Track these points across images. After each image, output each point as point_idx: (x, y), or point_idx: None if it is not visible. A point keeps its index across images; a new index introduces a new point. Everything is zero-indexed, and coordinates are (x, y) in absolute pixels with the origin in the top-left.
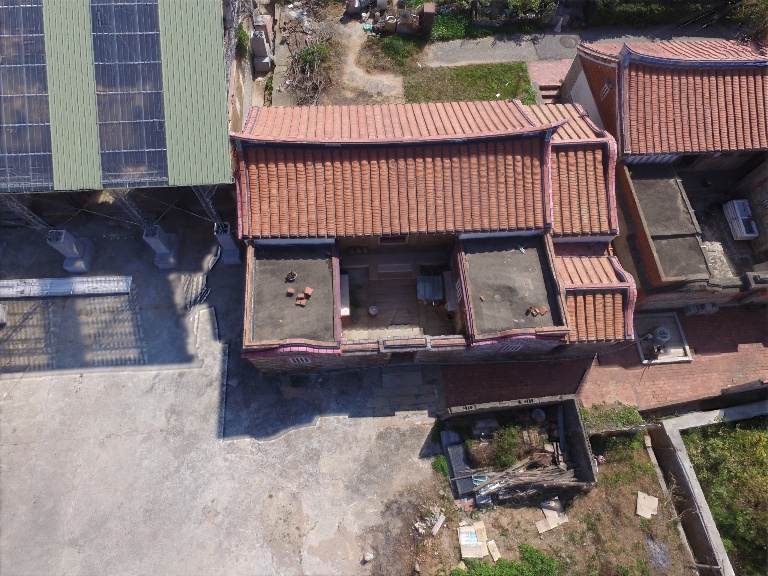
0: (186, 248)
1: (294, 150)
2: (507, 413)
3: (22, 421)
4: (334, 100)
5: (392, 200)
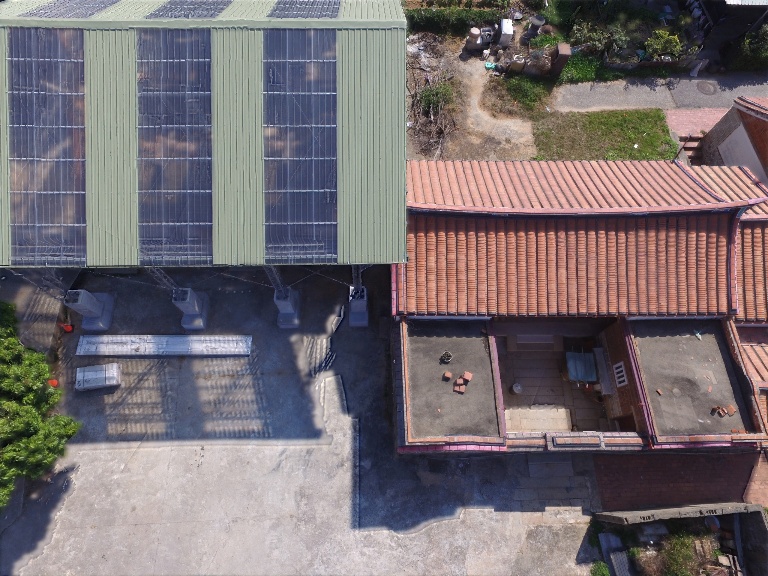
0: (307, 306)
1: (456, 218)
2: (680, 520)
3: (142, 498)
4: (459, 146)
5: (560, 277)
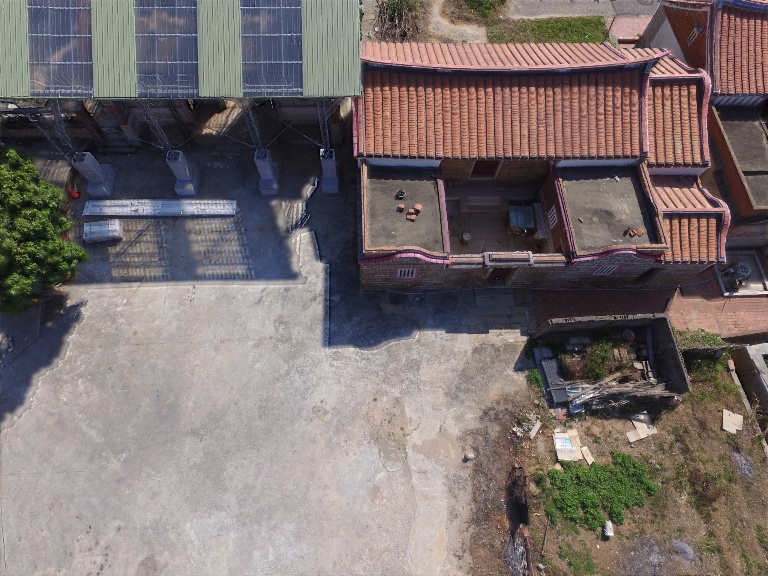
0: (285, 177)
1: (407, 75)
2: (600, 331)
3: (142, 324)
4: None
5: (497, 126)
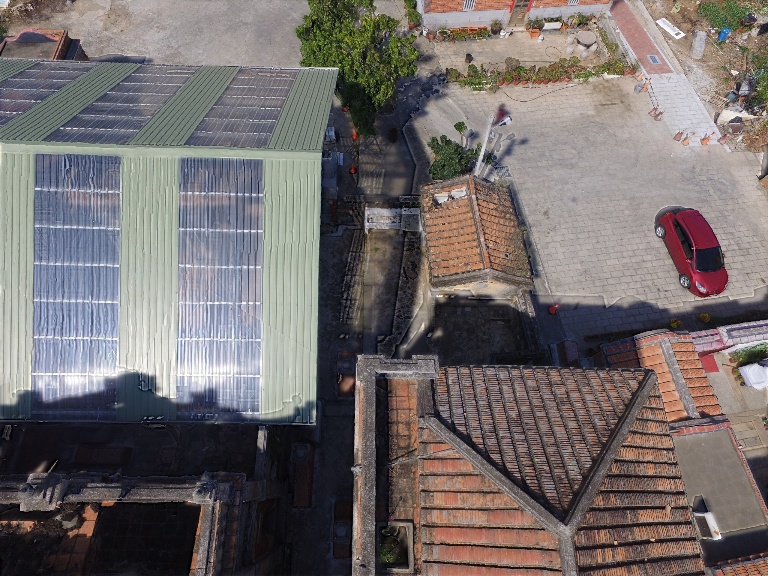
0: None
1: None
2: None
3: None
4: None
5: None
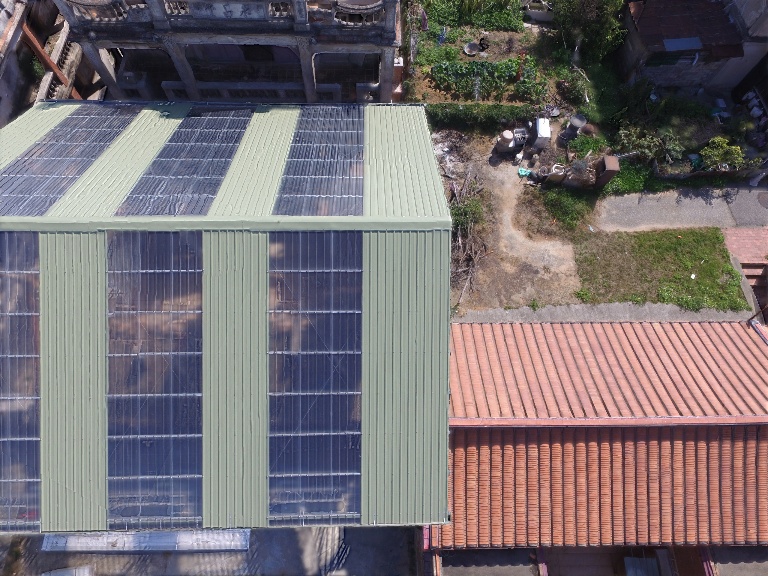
0: None
1: (502, 428)
2: None
3: None
4: (491, 276)
5: (628, 498)
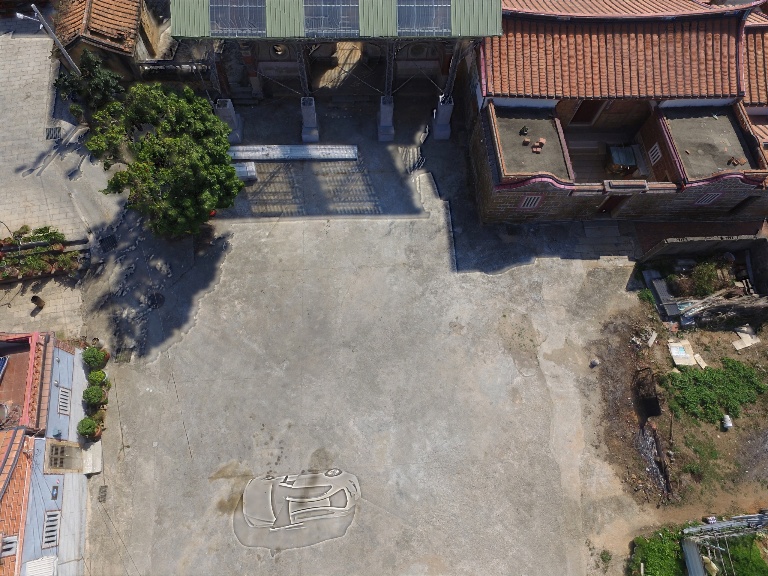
0: (398, 126)
1: (530, 23)
2: (705, 252)
3: (286, 253)
4: None
5: (610, 68)
